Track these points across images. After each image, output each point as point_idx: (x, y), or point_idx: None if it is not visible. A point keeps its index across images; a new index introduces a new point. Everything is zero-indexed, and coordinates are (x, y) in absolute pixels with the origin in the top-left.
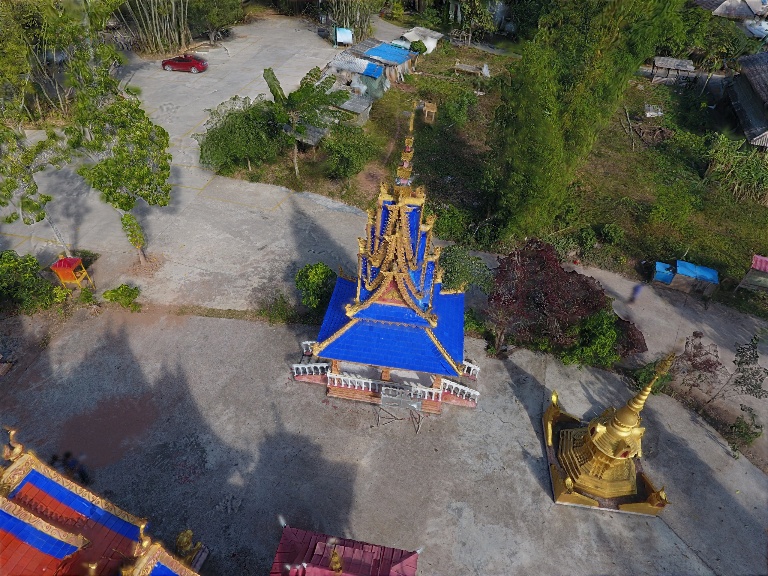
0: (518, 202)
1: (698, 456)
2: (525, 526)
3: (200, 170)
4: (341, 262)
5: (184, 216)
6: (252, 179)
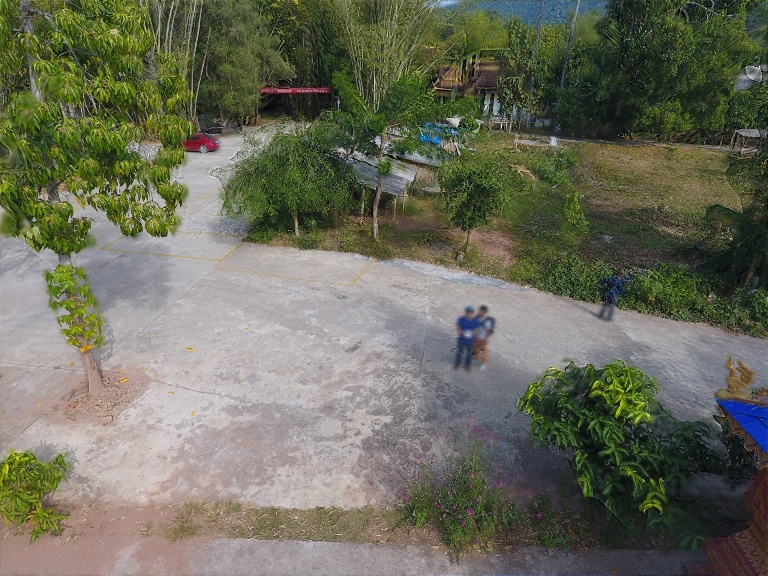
0: None
1: None
2: None
3: (216, 237)
4: (530, 369)
5: (190, 298)
6: (303, 244)
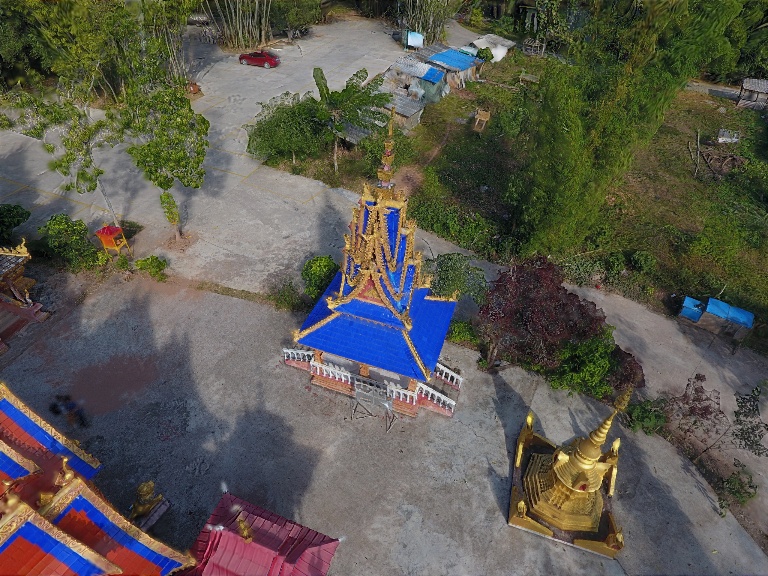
0: (540, 218)
1: (679, 506)
2: (471, 541)
3: (249, 159)
4: None
5: (225, 200)
6: (294, 171)
